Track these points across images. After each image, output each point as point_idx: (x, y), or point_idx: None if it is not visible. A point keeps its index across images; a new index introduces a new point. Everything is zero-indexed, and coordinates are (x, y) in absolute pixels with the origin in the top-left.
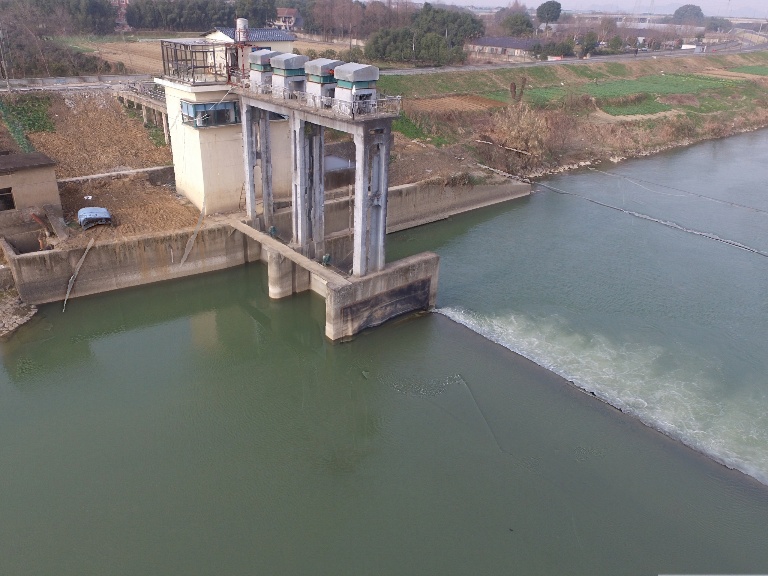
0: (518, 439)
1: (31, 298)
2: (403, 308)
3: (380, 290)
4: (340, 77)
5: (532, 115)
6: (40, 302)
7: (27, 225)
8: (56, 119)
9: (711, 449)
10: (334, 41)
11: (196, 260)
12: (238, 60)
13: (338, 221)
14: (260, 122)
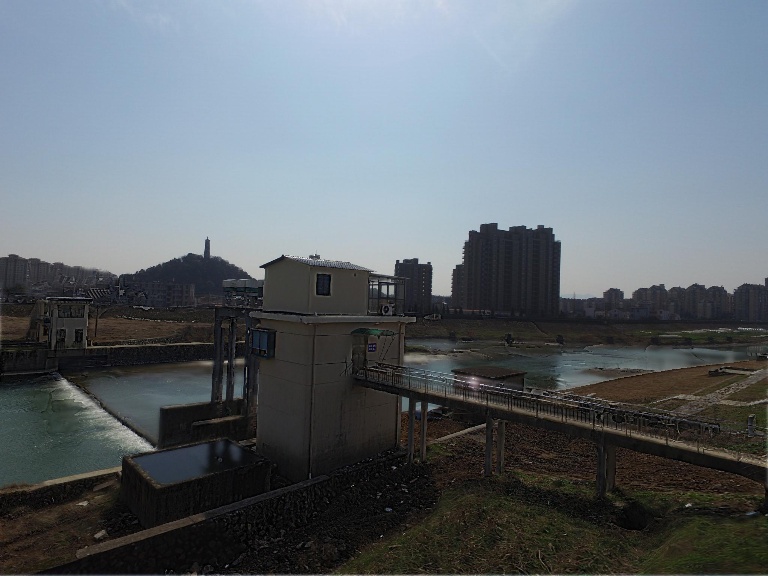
0: None
1: None
2: None
3: None
4: None
5: None
6: None
7: None
8: None
9: None
10: None
11: None
12: None
13: None
14: None
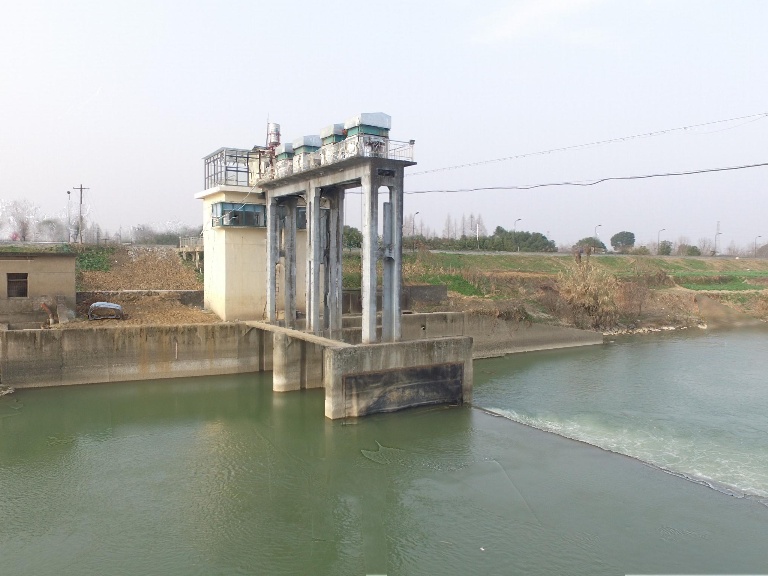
0: (568, 513)
1: (12, 380)
2: (428, 397)
3: (395, 365)
4: (349, 125)
5: (598, 272)
6: (21, 386)
7: (36, 315)
8: (114, 264)
9: None
10: None
11: (203, 359)
12: None
13: None
14: (286, 218)
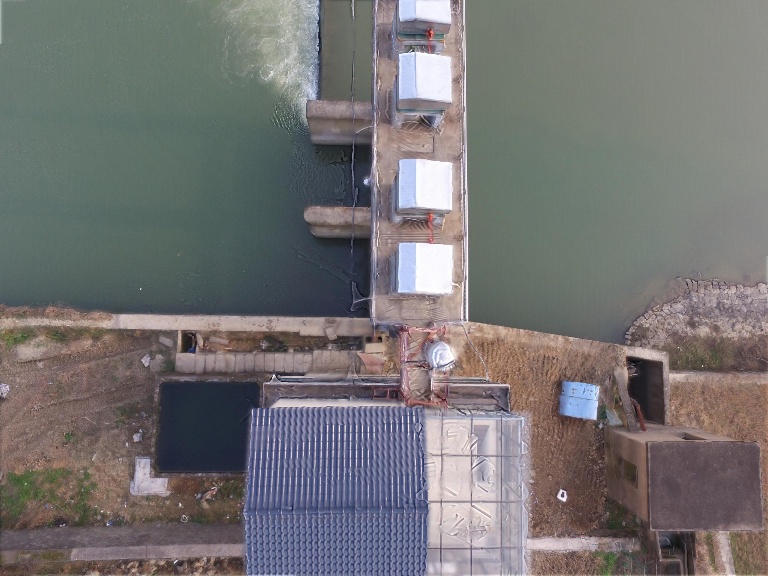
0: None
1: None
2: None
3: None
4: None
5: None
6: None
7: None
8: None
9: None
10: None
11: None
12: None
13: None
14: None
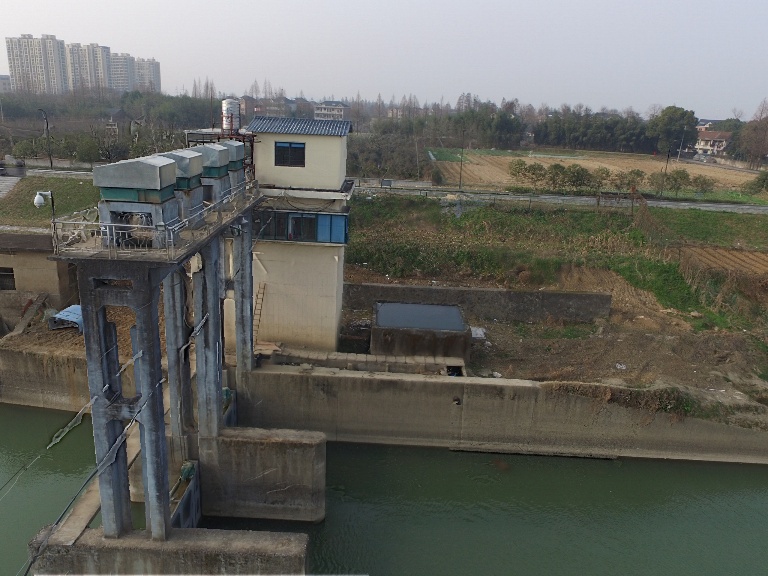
0: None
1: None
2: None
3: (144, 575)
4: None
5: None
6: None
7: None
8: None
9: None
10: (641, 159)
11: None
12: (254, 156)
13: (367, 407)
14: (234, 240)
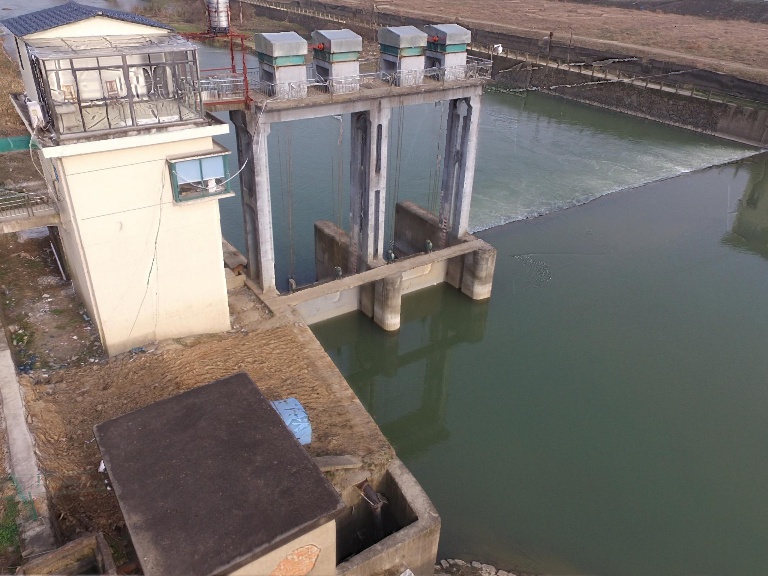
0: None
1: None
2: None
3: None
4: (455, 41)
5: (8, 83)
6: None
7: None
8: None
9: (568, 204)
10: None
11: None
12: None
13: None
14: None
